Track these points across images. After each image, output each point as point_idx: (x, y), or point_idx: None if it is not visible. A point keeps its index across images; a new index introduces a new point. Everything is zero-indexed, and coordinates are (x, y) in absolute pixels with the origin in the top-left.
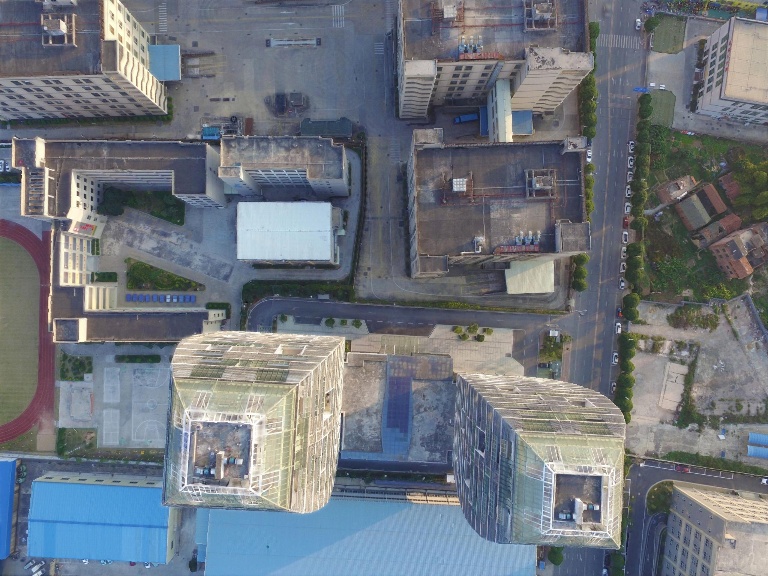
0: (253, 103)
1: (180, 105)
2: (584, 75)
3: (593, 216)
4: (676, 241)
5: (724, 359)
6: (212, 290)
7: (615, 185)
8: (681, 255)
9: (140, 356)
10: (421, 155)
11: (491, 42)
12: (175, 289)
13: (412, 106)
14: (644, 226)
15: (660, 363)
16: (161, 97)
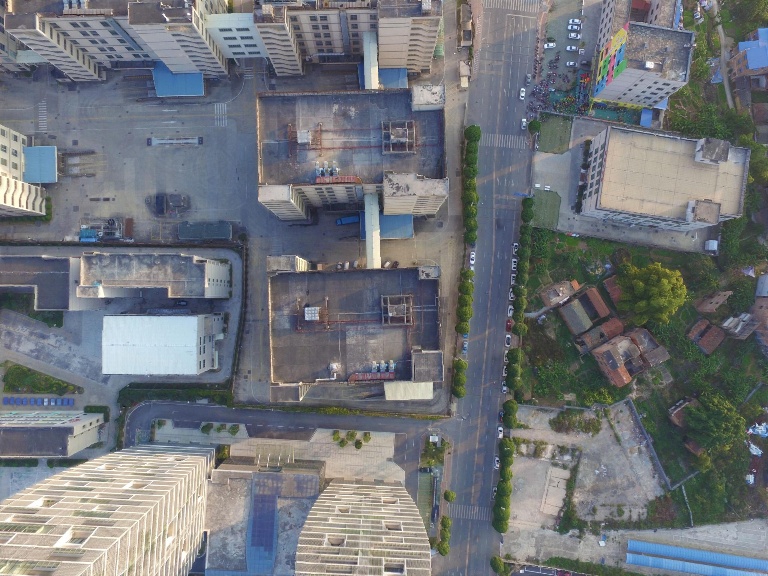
0: (133, 203)
1: (59, 205)
2: (444, 198)
3: (476, 318)
4: (558, 345)
5: (606, 464)
6: (91, 393)
7: (499, 287)
8: (563, 359)
9: (17, 460)
10: (277, 280)
11: (349, 164)
12: (53, 392)
13: (286, 214)
14: (522, 334)
15: (542, 468)
16: (36, 200)
